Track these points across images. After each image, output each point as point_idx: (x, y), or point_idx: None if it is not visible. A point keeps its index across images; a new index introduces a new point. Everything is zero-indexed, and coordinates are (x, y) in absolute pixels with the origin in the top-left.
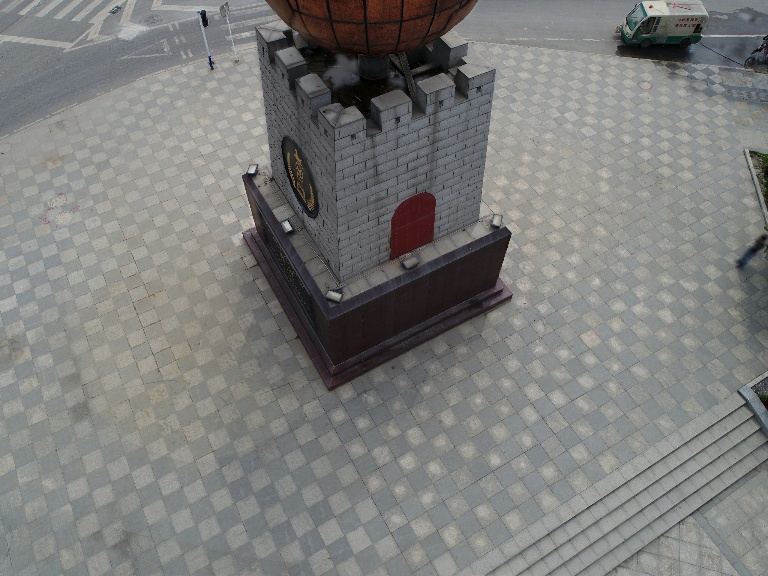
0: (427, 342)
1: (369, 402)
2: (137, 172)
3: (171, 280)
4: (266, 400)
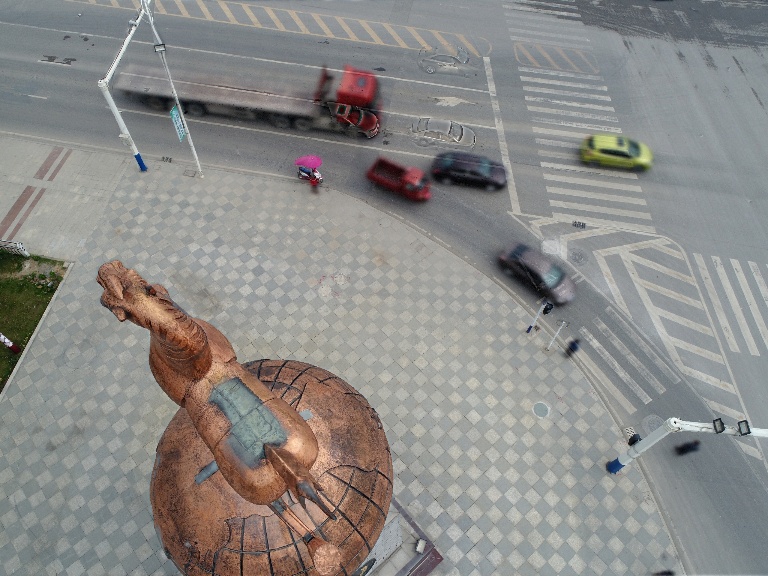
0: None
1: None
2: (382, 320)
3: None
4: None
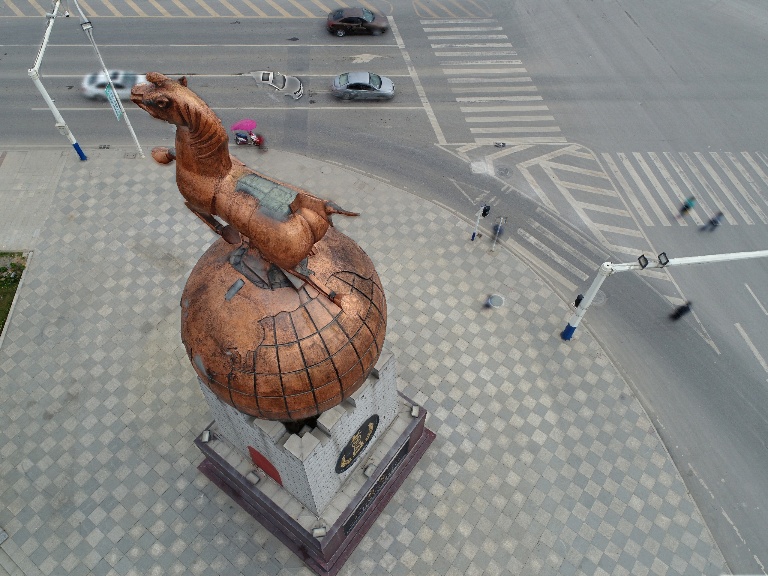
0: (262, 525)
1: (198, 501)
2: None
3: None
4: (181, 430)
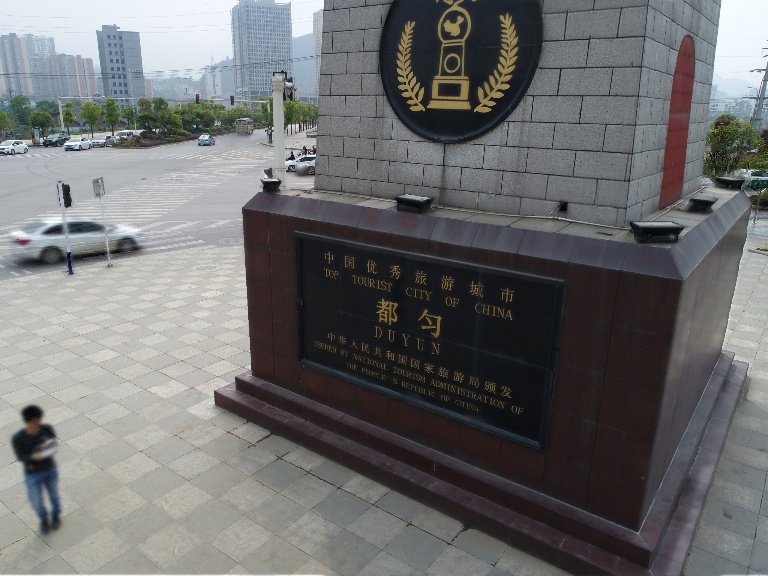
0: (722, 456)
1: None
2: None
3: (50, 508)
4: None
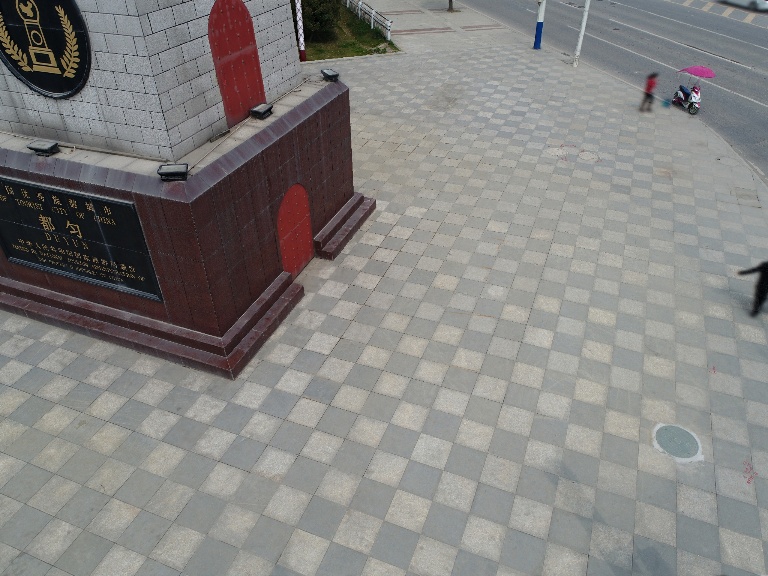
0: None
1: None
2: (579, 198)
3: (394, 162)
4: None
